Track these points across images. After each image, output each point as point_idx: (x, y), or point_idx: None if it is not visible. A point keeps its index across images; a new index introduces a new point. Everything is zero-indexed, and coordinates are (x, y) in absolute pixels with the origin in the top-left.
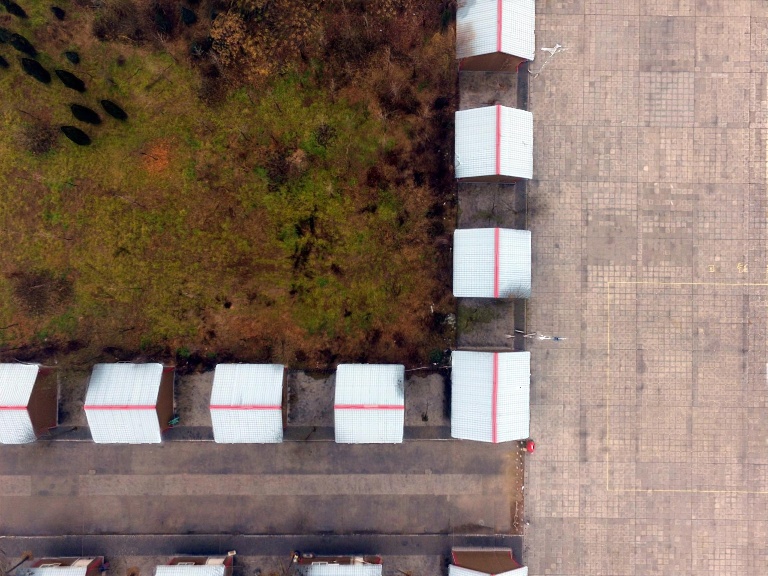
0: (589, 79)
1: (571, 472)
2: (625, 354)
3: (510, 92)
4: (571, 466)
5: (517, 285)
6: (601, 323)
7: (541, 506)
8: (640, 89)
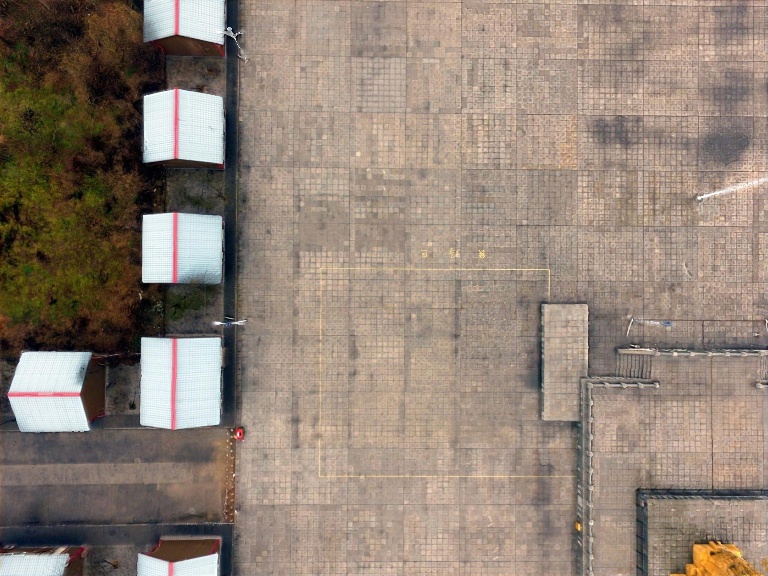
0: (300, 64)
1: (283, 459)
2: (337, 340)
3: (219, 77)
4: (283, 453)
5: (202, 270)
6: (313, 309)
7: (252, 494)
8: (352, 74)
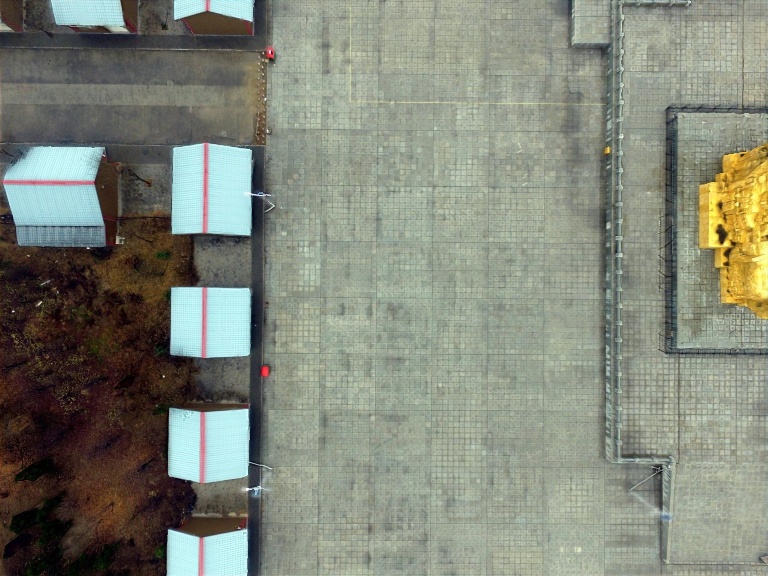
0: None
1: (314, 84)
2: None
3: None
4: (314, 78)
5: None
6: None
7: (284, 117)
8: None
